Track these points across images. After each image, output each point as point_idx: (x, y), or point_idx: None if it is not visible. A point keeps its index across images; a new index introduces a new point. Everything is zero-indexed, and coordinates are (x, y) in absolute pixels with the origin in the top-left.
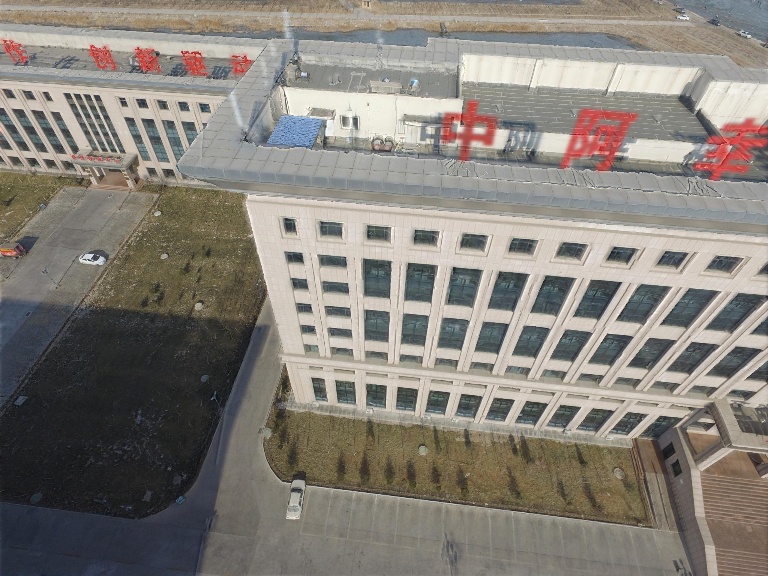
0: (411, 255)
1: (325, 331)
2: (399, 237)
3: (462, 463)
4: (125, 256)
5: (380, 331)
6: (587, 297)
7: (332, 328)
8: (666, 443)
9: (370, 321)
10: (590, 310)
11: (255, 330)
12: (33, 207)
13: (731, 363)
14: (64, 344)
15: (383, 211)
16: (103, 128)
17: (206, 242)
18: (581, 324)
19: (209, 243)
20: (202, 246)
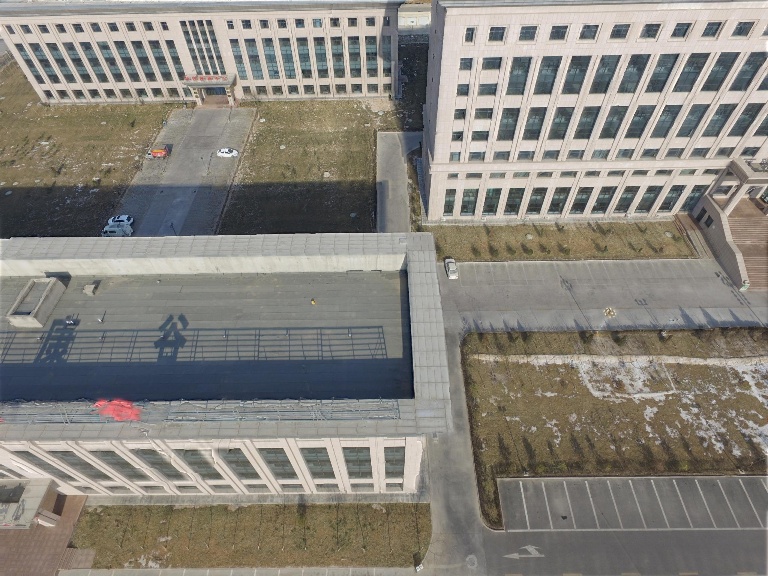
0: (546, 49)
1: (470, 135)
2: (541, 33)
3: (559, 240)
4: (251, 150)
5: (508, 130)
6: (655, 73)
7: (475, 132)
8: (699, 211)
9: (502, 121)
10: (656, 85)
11: (377, 184)
12: (155, 126)
13: (744, 122)
14: (234, 206)
15: (535, 13)
16: (209, 52)
17: (311, 135)
18: (649, 98)
19: (314, 136)
20: (309, 138)
